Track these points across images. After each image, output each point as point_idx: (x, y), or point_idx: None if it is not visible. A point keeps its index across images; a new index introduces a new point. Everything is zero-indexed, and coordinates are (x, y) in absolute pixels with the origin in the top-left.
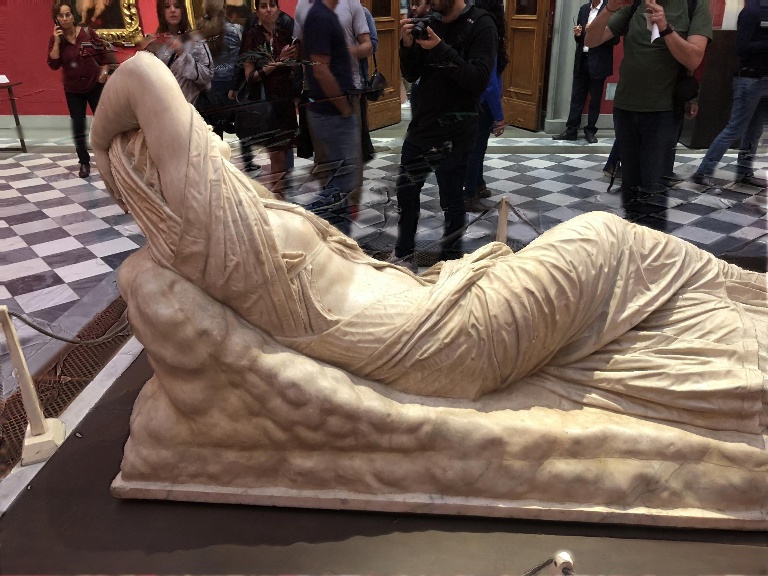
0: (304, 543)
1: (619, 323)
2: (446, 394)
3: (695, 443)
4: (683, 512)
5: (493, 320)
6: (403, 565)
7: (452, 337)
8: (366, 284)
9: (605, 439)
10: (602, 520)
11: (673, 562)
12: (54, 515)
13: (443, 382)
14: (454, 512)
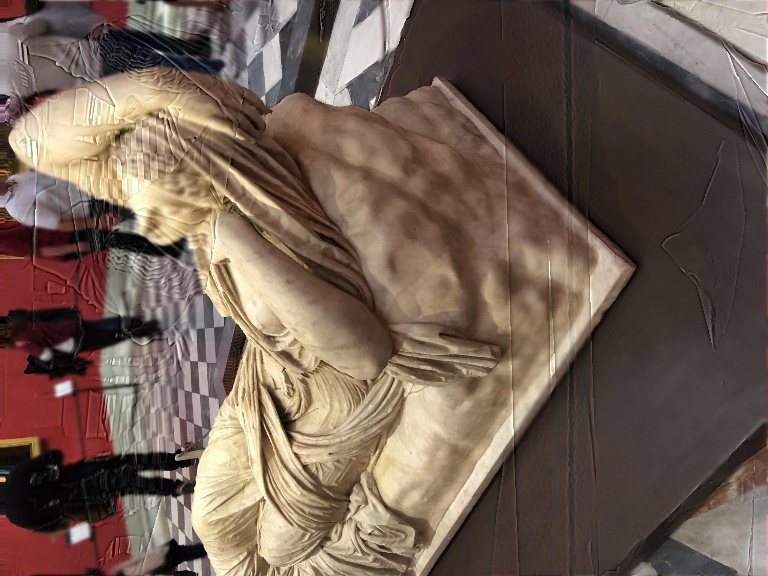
0: None
1: None
2: None
3: None
4: None
5: None
6: None
7: None
8: None
9: None
10: None
11: None
12: (460, 25)
13: None
14: None
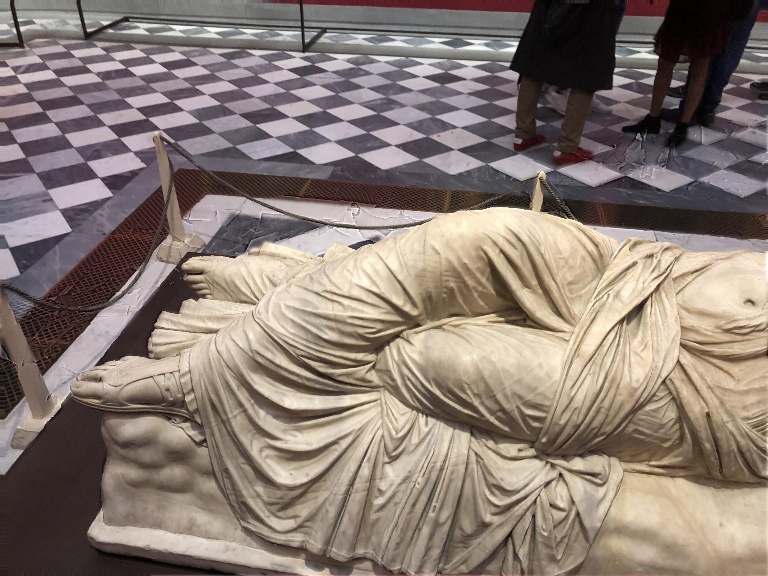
0: None
1: None
2: None
3: None
4: None
5: None
6: None
7: None
8: (764, 263)
9: None
10: None
11: None
12: None
13: None
14: None
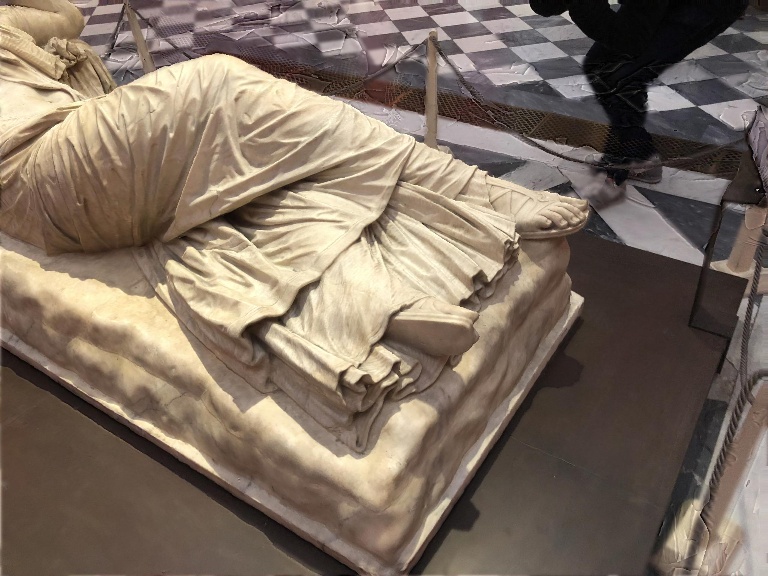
0: None
1: (192, 208)
2: (29, 240)
3: (195, 375)
4: (178, 445)
5: (36, 169)
6: None
7: (9, 179)
8: None
9: (124, 336)
10: (118, 419)
11: (141, 490)
12: None
13: (17, 226)
14: (24, 358)
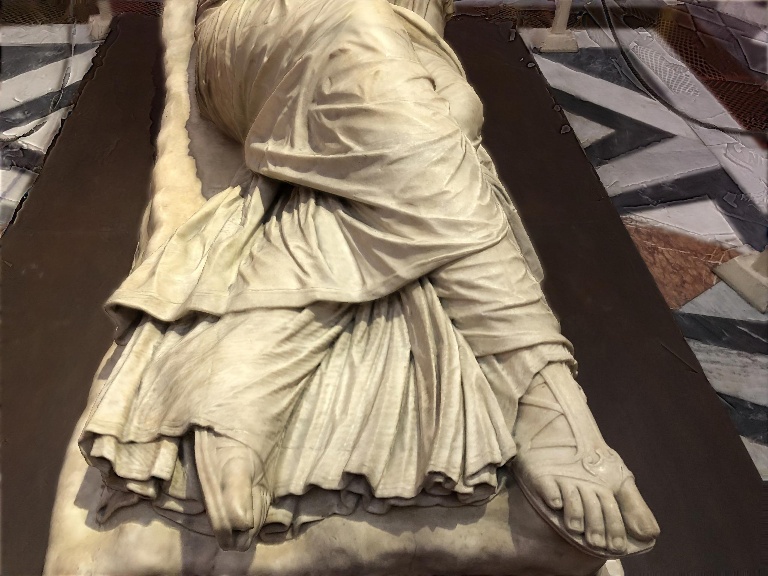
0: (151, 124)
1: None
2: None
3: None
4: None
5: (203, 29)
6: (119, 175)
7: None
8: None
9: None
10: None
11: (82, 362)
12: None
13: None
14: None
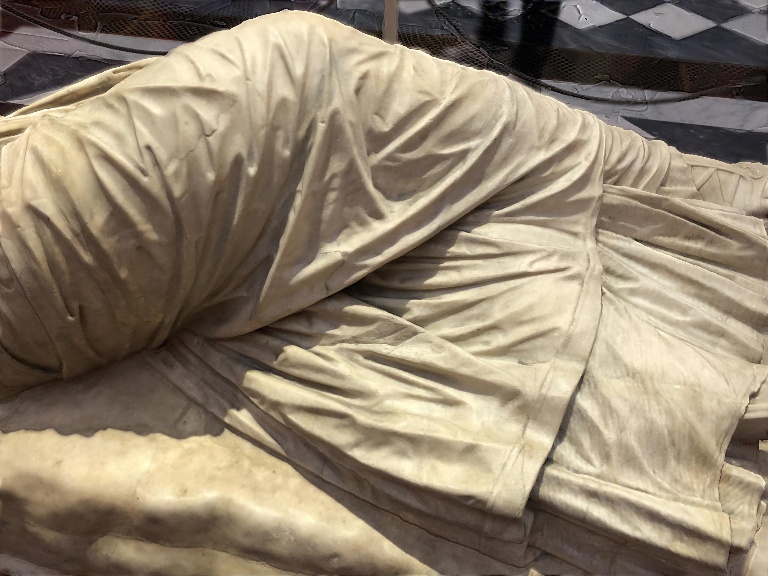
0: None
1: (295, 286)
2: None
3: (382, 563)
4: None
5: None
6: None
7: None
8: None
9: (213, 519)
10: None
11: None
12: None
13: None
14: None
